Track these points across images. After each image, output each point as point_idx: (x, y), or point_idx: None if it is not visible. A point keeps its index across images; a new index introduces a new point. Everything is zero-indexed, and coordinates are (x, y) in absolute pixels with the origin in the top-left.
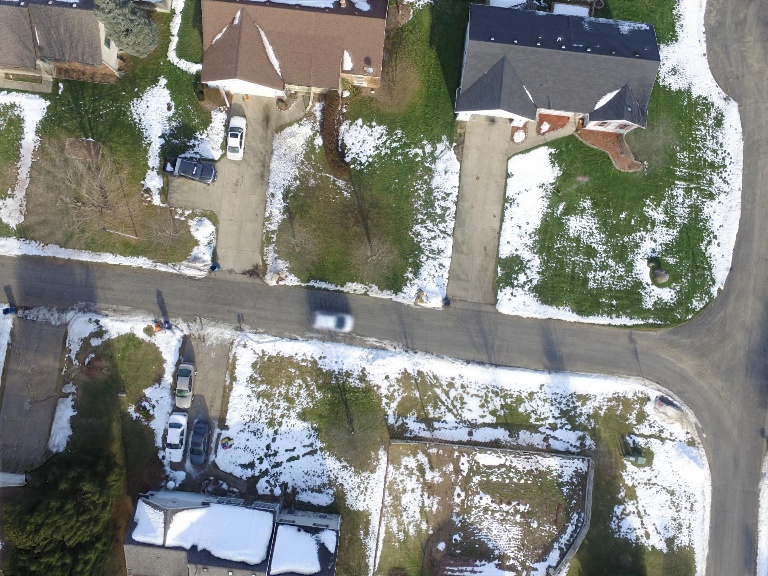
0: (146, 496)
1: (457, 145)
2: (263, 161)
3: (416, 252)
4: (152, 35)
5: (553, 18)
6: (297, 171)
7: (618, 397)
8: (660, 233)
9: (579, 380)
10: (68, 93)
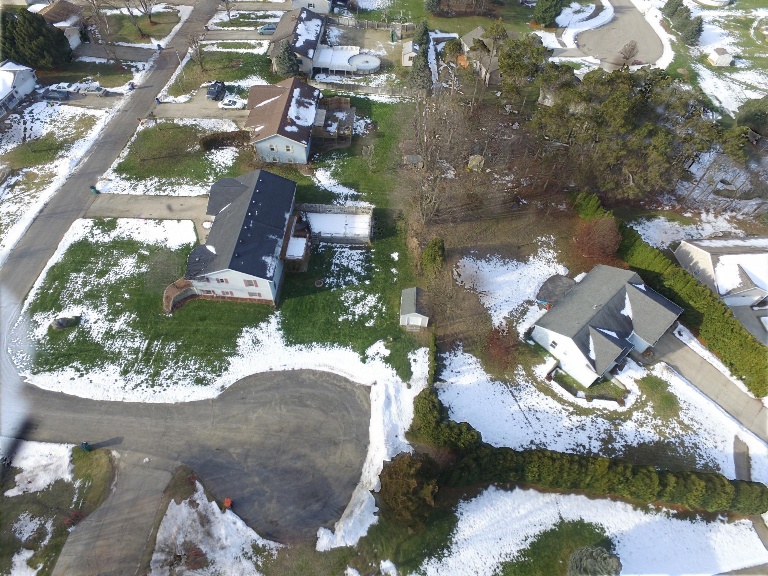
0: (33, 71)
1: None
2: (217, 116)
3: (139, 179)
4: (287, 74)
5: (281, 220)
6: (208, 129)
7: None
8: (102, 327)
9: None
10: (266, 59)
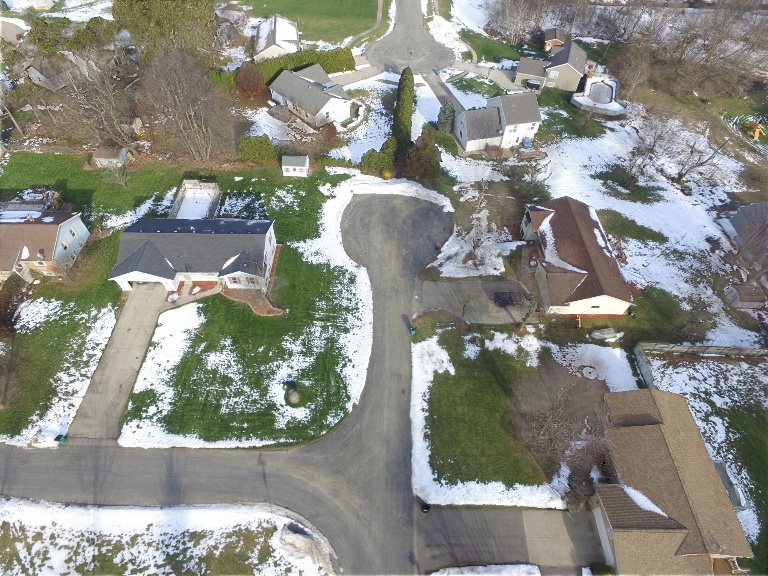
0: None
1: (118, 308)
2: None
3: (50, 396)
4: None
5: (199, 221)
6: None
7: (239, 530)
8: (297, 361)
9: (194, 513)
10: None
